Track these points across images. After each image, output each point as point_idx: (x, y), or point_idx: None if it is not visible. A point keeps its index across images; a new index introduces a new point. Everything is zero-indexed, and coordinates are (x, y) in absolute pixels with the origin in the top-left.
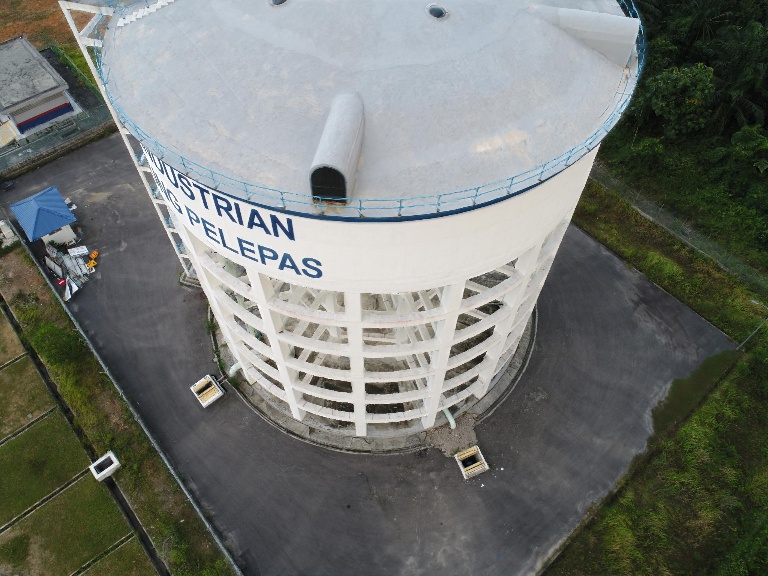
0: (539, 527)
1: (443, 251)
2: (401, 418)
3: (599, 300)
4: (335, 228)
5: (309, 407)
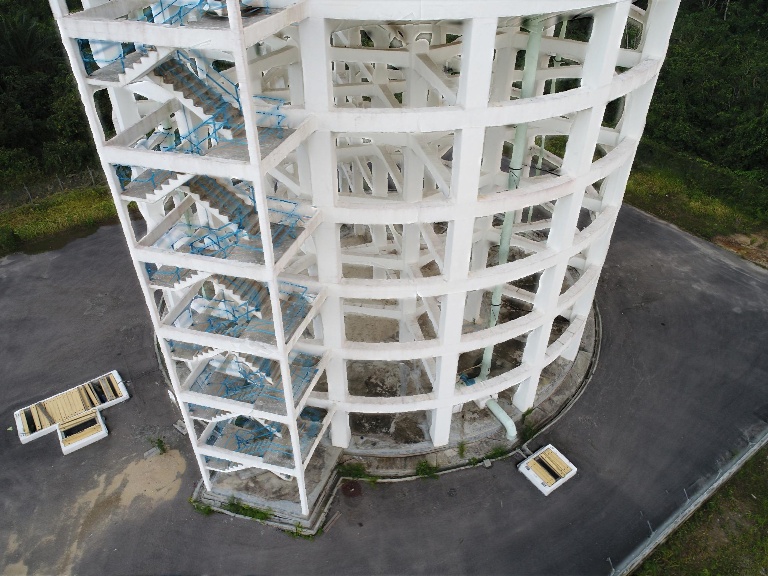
0: (630, 217)
1: None
2: None
3: None
4: None
5: None
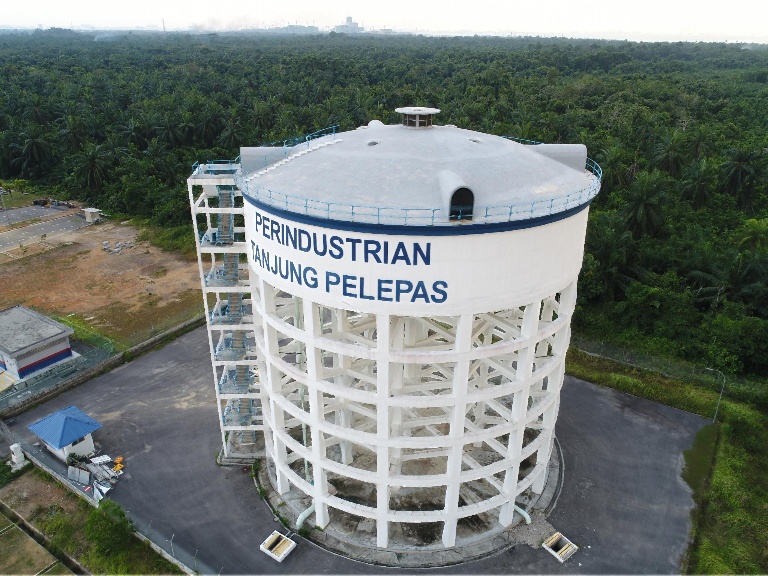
0: None
1: (529, 265)
2: (488, 505)
3: (592, 411)
4: (462, 244)
5: (400, 514)
